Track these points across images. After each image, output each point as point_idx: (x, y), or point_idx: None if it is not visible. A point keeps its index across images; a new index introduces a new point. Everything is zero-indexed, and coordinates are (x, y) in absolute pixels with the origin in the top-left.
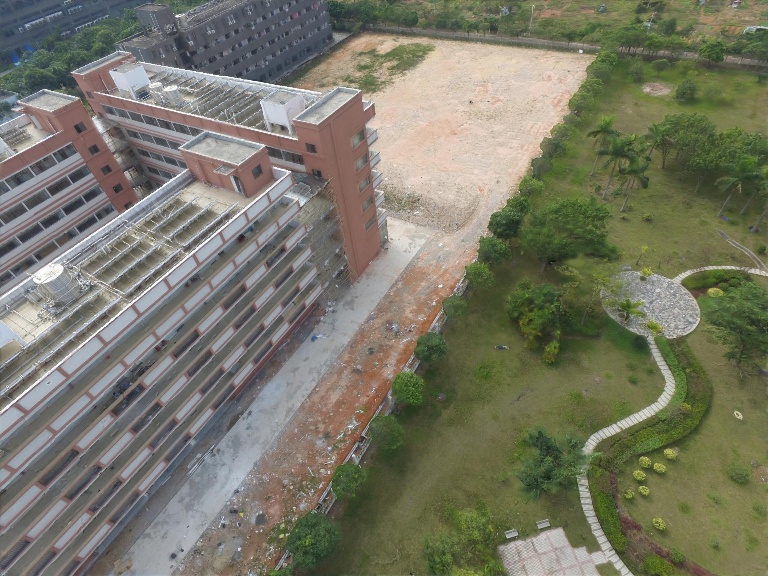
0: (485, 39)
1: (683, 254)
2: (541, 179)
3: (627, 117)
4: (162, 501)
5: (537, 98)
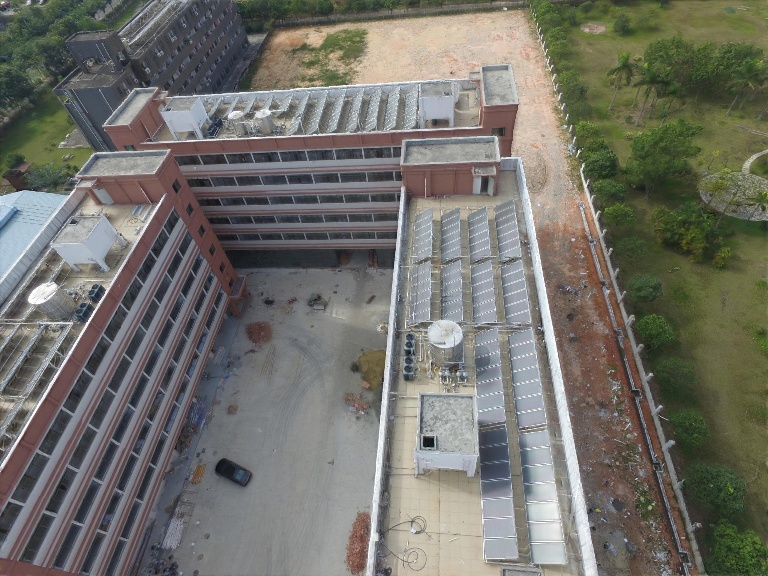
0: (410, 14)
1: (731, 151)
2: (575, 123)
3: (592, 56)
4: None
5: (506, 56)
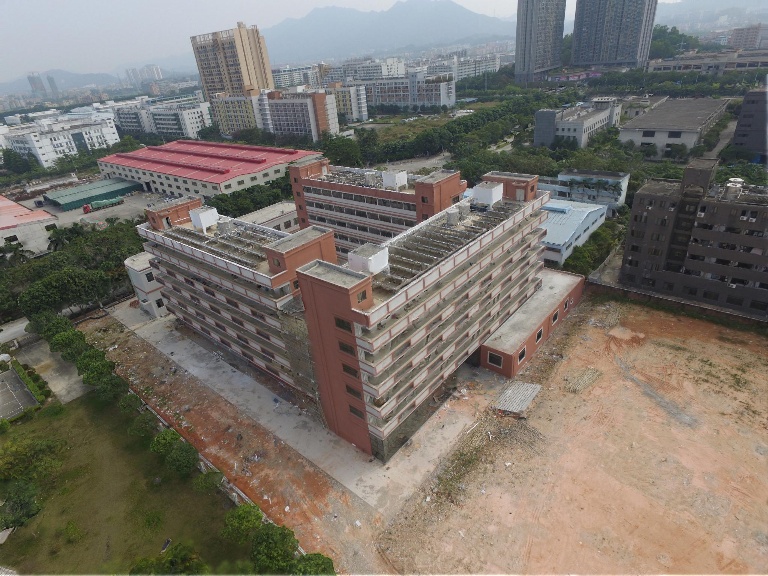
0: None
1: None
2: None
3: None
4: (206, 345)
5: None
